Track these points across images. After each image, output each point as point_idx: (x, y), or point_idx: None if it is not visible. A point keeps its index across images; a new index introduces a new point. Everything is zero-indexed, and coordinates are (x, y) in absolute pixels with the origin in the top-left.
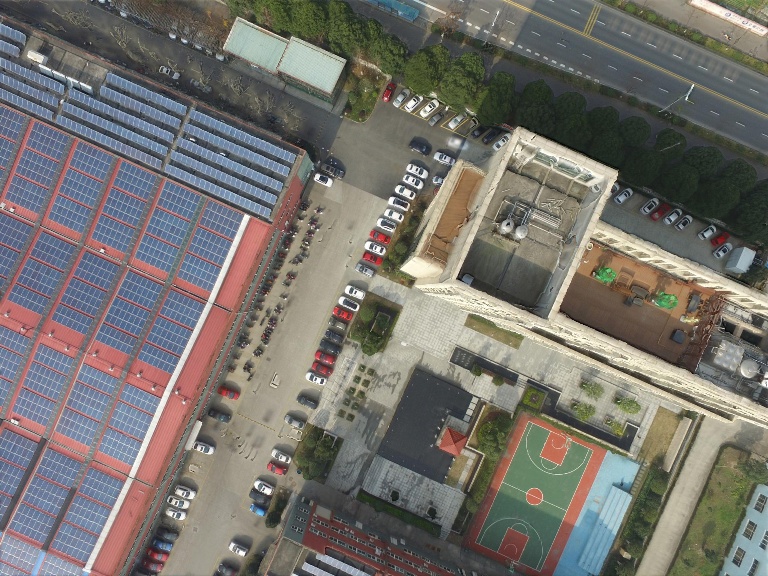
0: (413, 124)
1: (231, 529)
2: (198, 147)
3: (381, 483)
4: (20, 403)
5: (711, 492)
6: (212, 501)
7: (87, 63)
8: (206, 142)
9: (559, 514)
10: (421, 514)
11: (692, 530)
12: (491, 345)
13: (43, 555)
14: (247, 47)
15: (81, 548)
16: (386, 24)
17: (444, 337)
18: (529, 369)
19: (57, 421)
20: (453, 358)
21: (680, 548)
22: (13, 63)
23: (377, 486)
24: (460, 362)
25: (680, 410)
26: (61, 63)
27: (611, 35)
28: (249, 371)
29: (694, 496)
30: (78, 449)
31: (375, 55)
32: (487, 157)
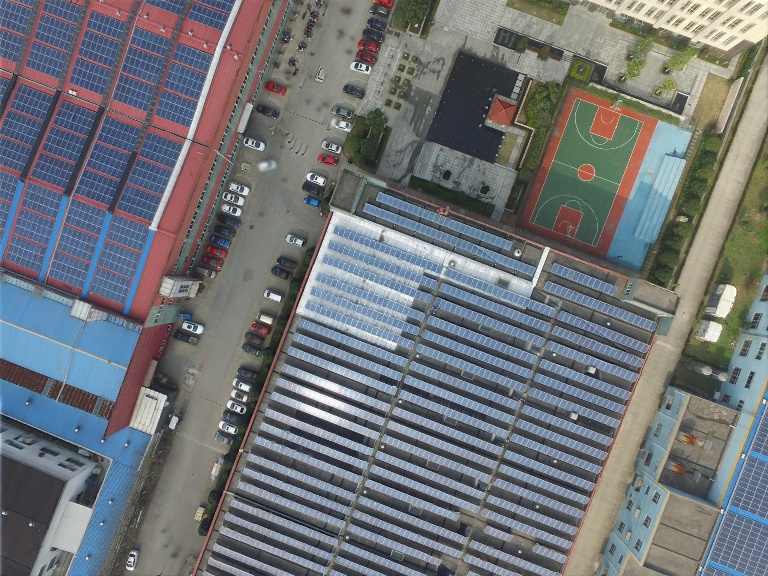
0: None
1: (286, 224)
2: None
3: (432, 167)
4: (76, 73)
5: (766, 156)
6: (266, 198)
7: None
8: None
9: (612, 188)
10: (474, 195)
11: (748, 196)
12: (534, 23)
13: (110, 217)
14: None
15: (146, 208)
16: None
17: (486, 19)
18: (574, 45)
19: (113, 89)
20: (496, 40)
21: (737, 214)
22: None
23: (428, 170)
24: (504, 43)
25: (730, 75)
26: None
27: None
28: (294, 65)
29: (749, 162)
30: (136, 116)
31: None
32: None
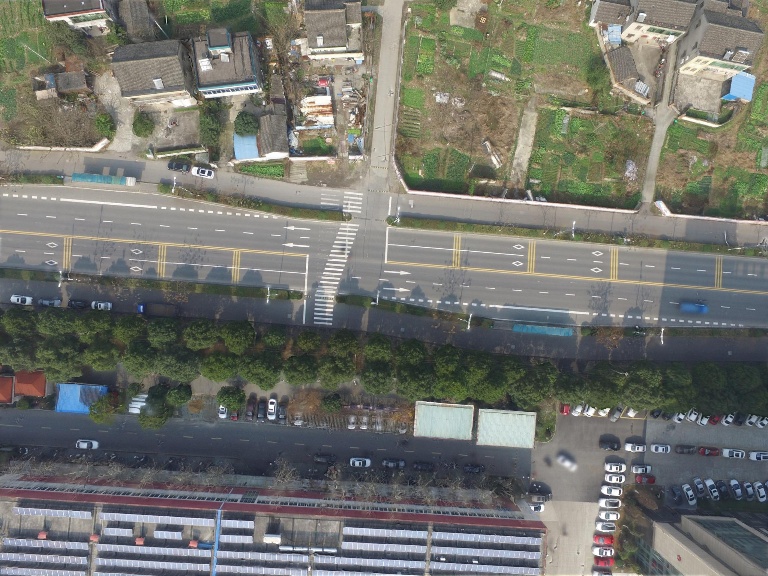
0: (595, 424)
1: None
2: (451, 565)
3: None
4: None
5: None
6: None
7: (319, 524)
8: (454, 554)
9: None
10: None
11: None
12: None
13: None
14: (435, 426)
15: None
16: (539, 342)
17: None
18: None
19: None
20: None
21: None
22: (252, 553)
23: None
24: None
25: None
26: (293, 532)
27: (740, 281)
28: None
29: None
30: None
31: (563, 402)
32: (671, 430)
